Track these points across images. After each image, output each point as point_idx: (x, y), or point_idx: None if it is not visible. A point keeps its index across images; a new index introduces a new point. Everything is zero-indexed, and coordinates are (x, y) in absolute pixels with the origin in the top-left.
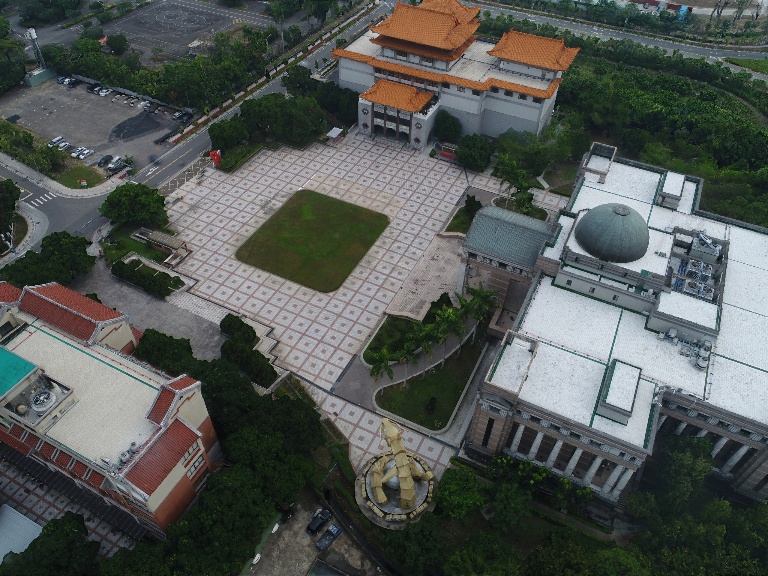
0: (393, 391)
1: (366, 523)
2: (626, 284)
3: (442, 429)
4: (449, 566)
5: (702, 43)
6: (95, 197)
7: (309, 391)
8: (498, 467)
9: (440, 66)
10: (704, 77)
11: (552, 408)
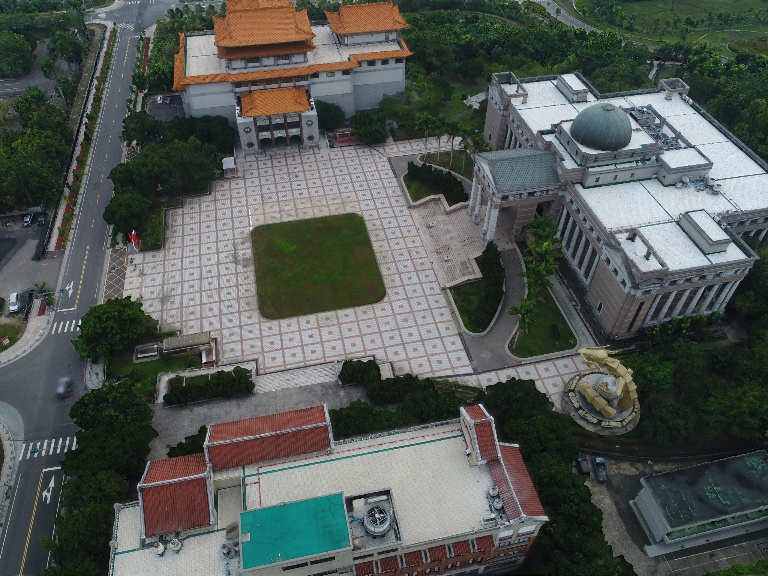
0: (518, 340)
1: (614, 439)
2: (633, 162)
3: (577, 343)
4: (709, 416)
5: None
6: (35, 349)
7: (460, 383)
8: (653, 338)
9: (297, 60)
10: (453, 6)
11: (683, 267)
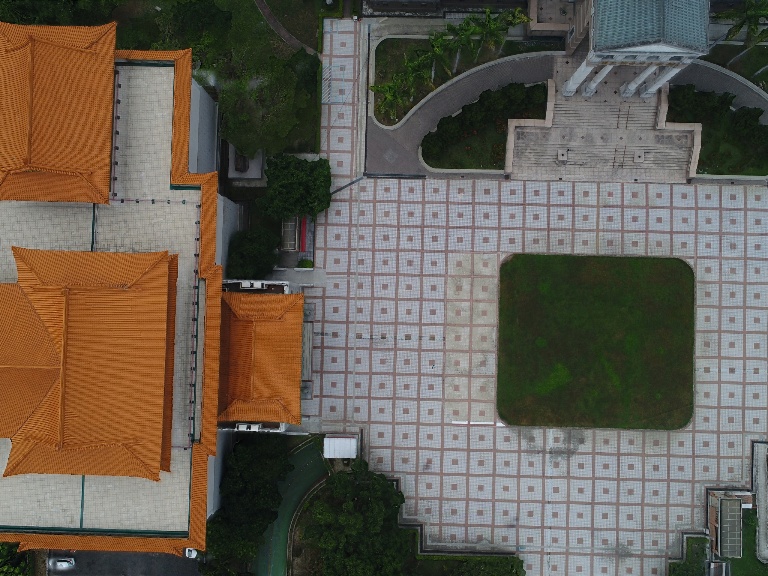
0: None
1: None
2: None
3: None
4: None
5: None
6: None
7: None
8: None
9: None
10: None
11: None
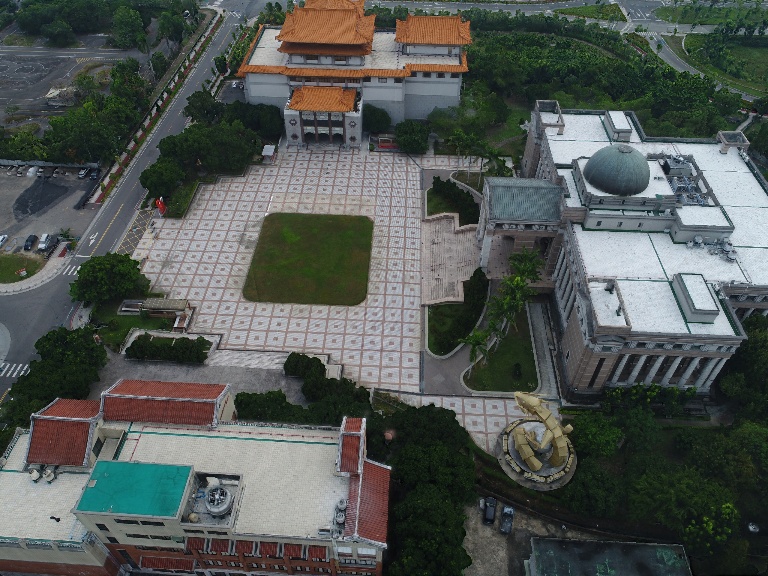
0: (476, 371)
1: (533, 493)
2: (645, 211)
3: (537, 388)
4: (636, 494)
5: (530, 1)
6: (45, 284)
7: (402, 400)
8: (613, 399)
9: (354, 62)
10: (549, 29)
11: (654, 330)
